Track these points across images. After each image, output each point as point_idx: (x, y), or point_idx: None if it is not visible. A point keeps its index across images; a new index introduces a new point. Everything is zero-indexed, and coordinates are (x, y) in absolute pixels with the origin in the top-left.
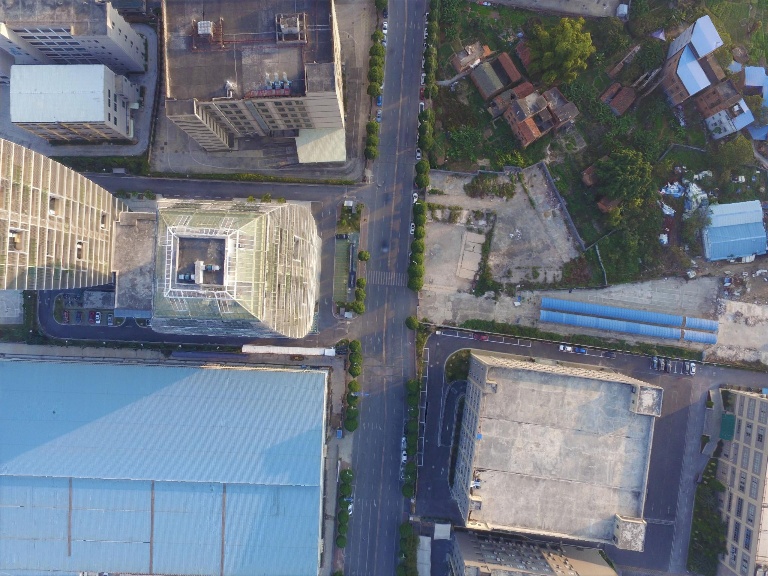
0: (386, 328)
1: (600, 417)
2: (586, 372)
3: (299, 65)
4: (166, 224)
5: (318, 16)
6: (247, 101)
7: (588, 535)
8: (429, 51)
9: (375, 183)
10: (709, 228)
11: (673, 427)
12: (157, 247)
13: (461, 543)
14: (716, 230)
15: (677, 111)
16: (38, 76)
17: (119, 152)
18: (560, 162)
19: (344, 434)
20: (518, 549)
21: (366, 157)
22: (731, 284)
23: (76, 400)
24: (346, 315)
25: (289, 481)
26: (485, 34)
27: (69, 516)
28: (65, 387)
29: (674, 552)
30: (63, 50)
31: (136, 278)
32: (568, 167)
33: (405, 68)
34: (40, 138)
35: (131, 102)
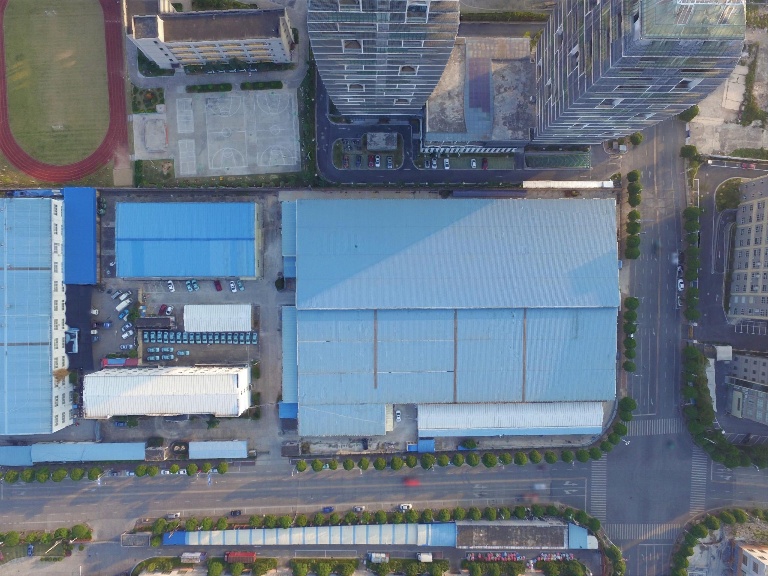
0: (656, 161)
1: None
2: None
3: None
4: None
5: None
6: None
7: None
8: None
9: None
10: None
11: None
12: None
13: (753, 357)
14: None
15: None
16: None
17: None
18: None
19: None
20: None
21: None
22: None
23: (376, 234)
24: (621, 148)
25: (590, 302)
26: None
27: (374, 349)
28: (364, 222)
29: None
30: None
31: (445, 102)
32: None
33: None
34: None
35: None
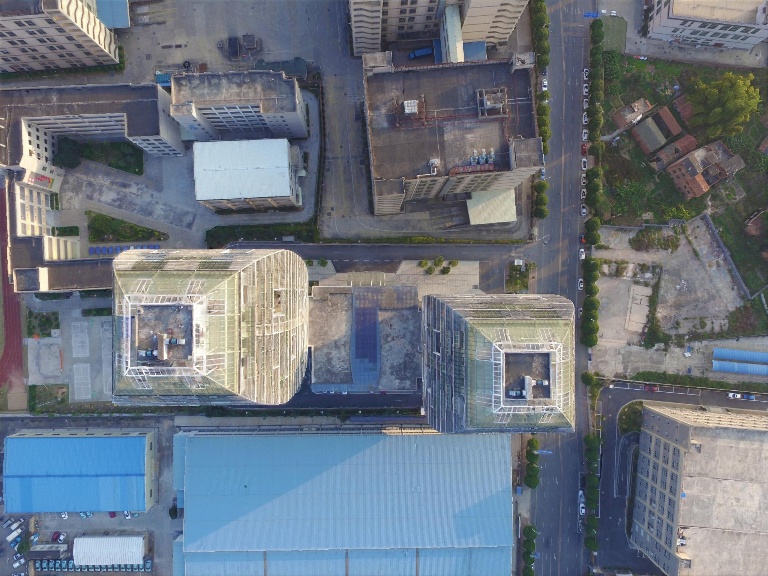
0: None
1: None
2: (765, 421)
3: (501, 139)
4: (490, 340)
5: (517, 89)
6: (453, 177)
7: None
8: (596, 109)
9: (541, 240)
10: None
11: None
12: (469, 359)
13: None
14: None
15: None
16: (222, 153)
17: (285, 219)
18: (721, 212)
19: (522, 490)
20: None
21: (536, 216)
22: None
23: (266, 473)
24: None
25: (483, 543)
26: (642, 88)
27: None
28: (254, 460)
29: None
30: (234, 122)
31: (331, 352)
32: (730, 217)
33: (566, 125)
34: (205, 208)
35: (299, 170)
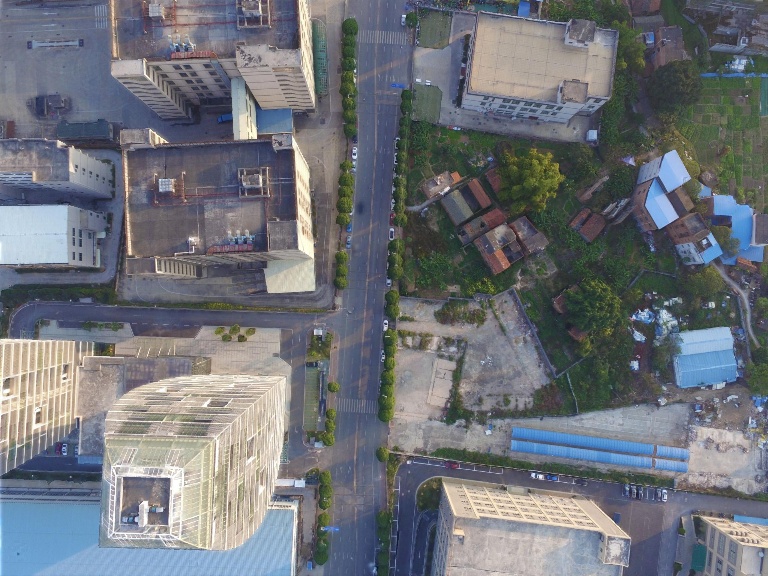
0: (357, 456)
1: (568, 564)
2: (556, 507)
3: (262, 219)
4: (110, 462)
5: (281, 169)
6: (209, 257)
7: None
8: (398, 181)
9: (345, 310)
10: (679, 356)
11: (645, 554)
12: None
13: None
14: (686, 358)
15: (647, 237)
16: (0, 218)
17: (86, 279)
18: (531, 287)
19: (315, 564)
20: None
21: None
22: (702, 410)
23: (41, 541)
24: (316, 445)
25: None
26: (455, 158)
27: None
28: (30, 527)
29: None
30: (28, 183)
31: (100, 423)
32: (539, 293)
33: (375, 193)
34: None
35: (98, 232)
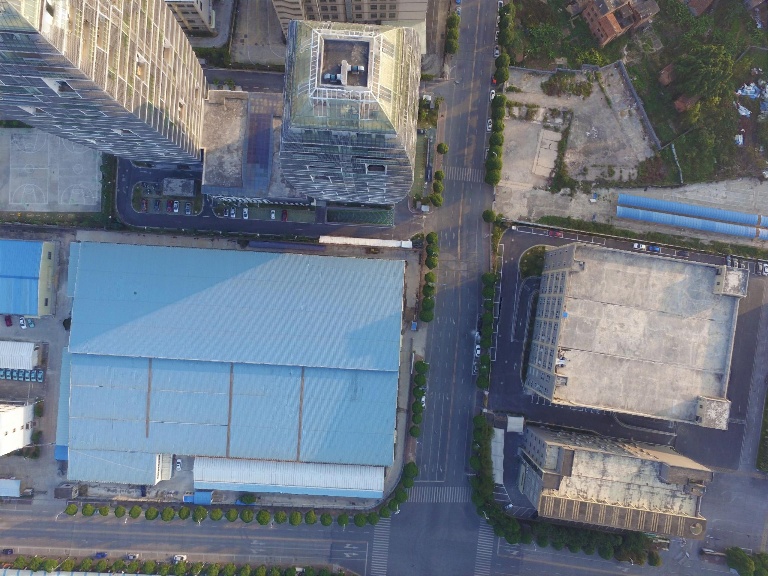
0: (461, 223)
1: (684, 299)
2: None
3: None
4: (311, 27)
5: None
6: None
7: (671, 416)
8: None
9: (453, 80)
10: None
11: (745, 327)
12: (296, 57)
13: (537, 432)
14: None
15: (754, 14)
16: None
17: (199, 44)
18: (637, 63)
19: (418, 327)
20: (593, 439)
21: (446, 51)
22: None
23: (157, 282)
24: (423, 208)
25: (368, 365)
26: None
27: (148, 397)
28: (146, 269)
29: (744, 451)
30: None
31: (223, 156)
32: (645, 67)
33: None
34: None
35: None
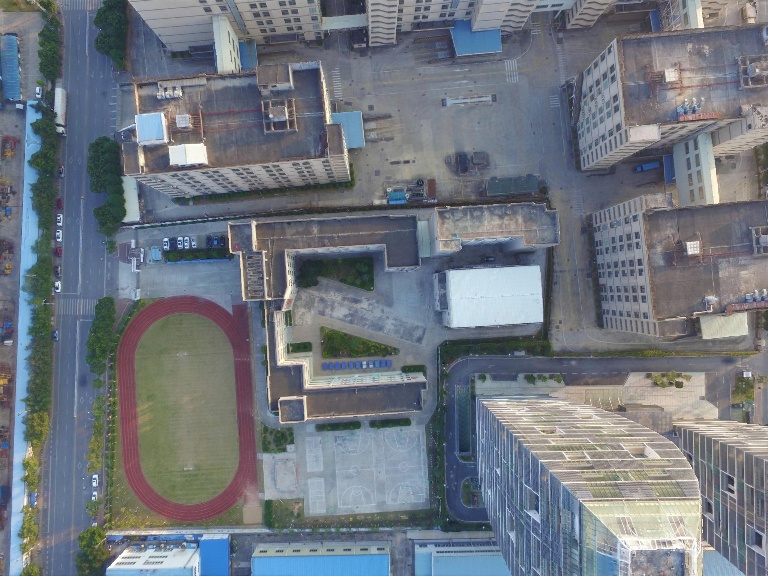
0: None
1: None
2: None
3: None
4: None
5: None
6: (730, 315)
7: None
8: None
9: (766, 350)
10: None
11: None
12: None
13: None
14: None
15: None
16: (477, 281)
17: (513, 332)
18: None
19: None
20: None
21: (766, 329)
22: None
23: None
24: None
25: None
26: None
27: None
28: None
29: None
30: None
31: None
32: None
33: None
34: (434, 322)
35: None
